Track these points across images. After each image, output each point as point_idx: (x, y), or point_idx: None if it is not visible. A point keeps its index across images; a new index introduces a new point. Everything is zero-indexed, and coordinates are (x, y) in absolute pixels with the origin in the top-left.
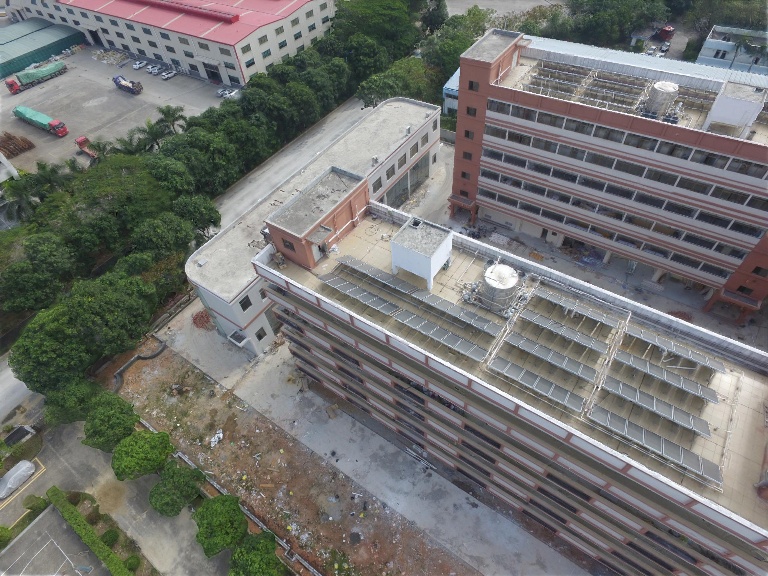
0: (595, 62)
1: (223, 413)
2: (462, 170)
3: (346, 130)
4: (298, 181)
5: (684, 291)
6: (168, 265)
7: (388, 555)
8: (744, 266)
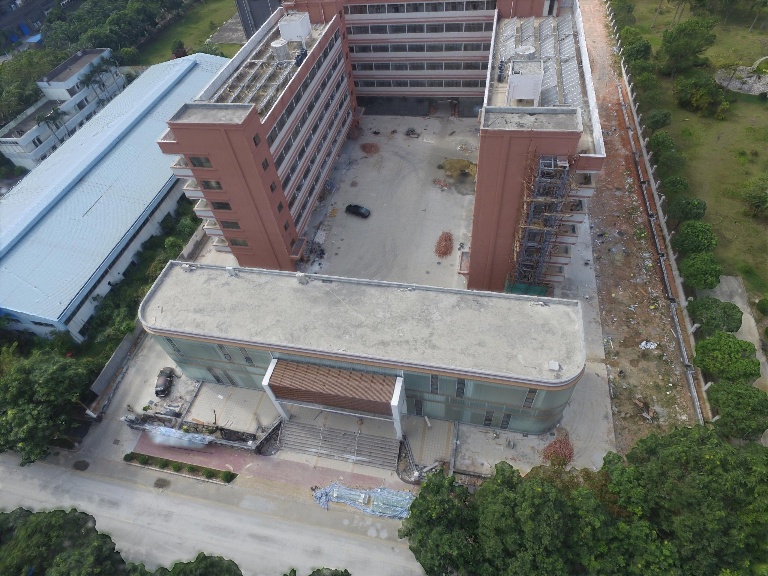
0: (209, 89)
1: (627, 355)
2: (284, 225)
3: (85, 494)
4: (360, 347)
5: (342, 148)
6: (561, 471)
7: (614, 217)
8: (350, 97)
